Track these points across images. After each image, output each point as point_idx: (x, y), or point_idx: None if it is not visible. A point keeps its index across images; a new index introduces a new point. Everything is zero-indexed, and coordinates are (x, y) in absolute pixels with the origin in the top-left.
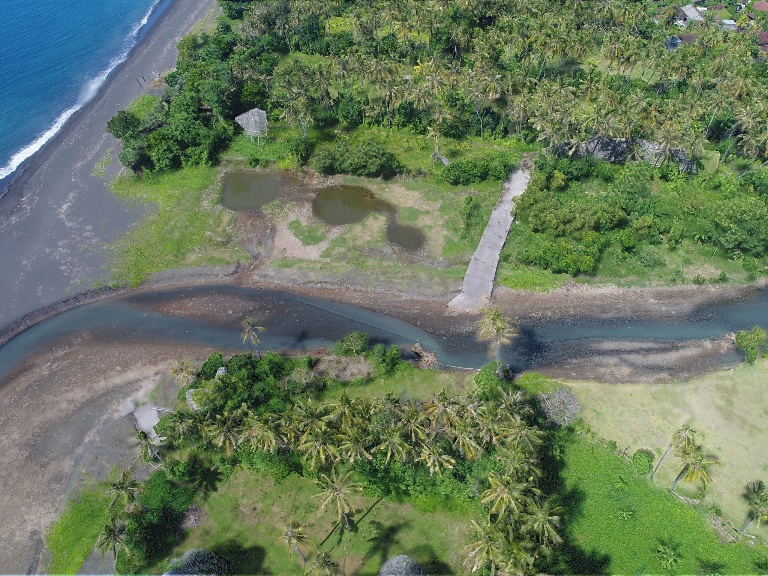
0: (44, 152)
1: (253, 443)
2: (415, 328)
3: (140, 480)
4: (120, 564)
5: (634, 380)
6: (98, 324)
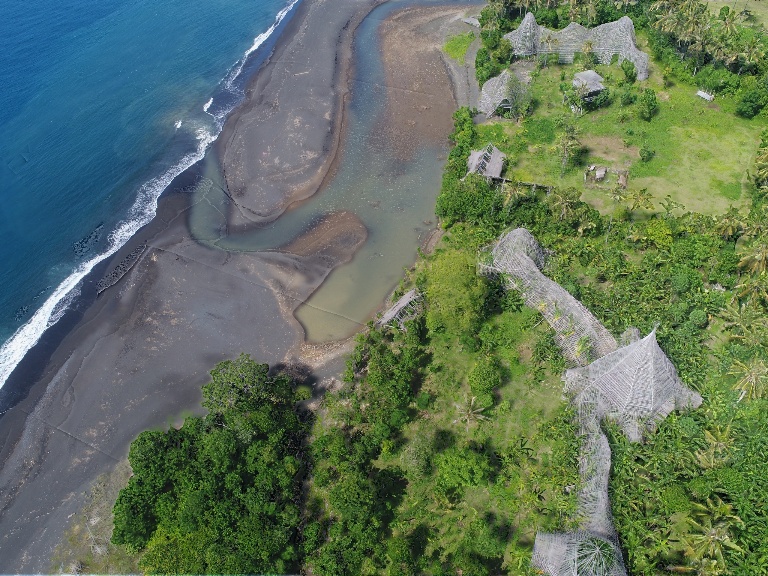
0: None
1: (538, 4)
2: None
3: (478, 32)
4: (489, 41)
5: None
6: (420, 0)
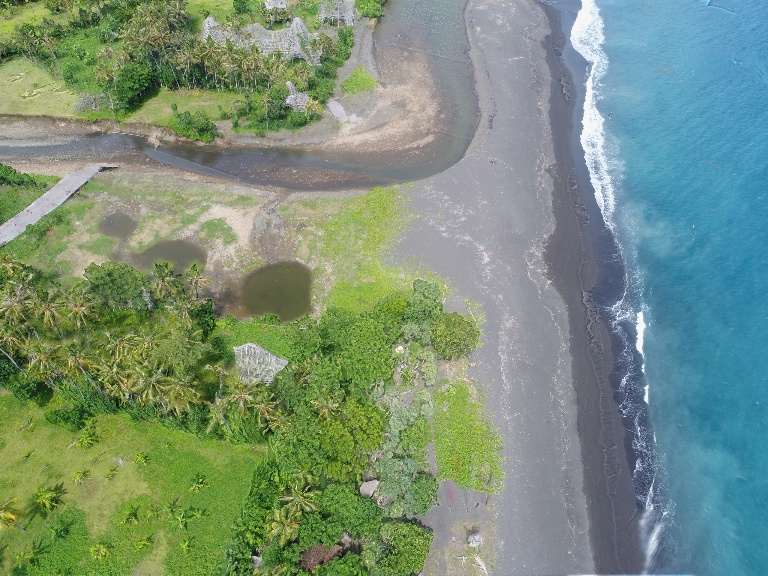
0: (590, 372)
1: None
2: (153, 157)
3: (335, 91)
4: None
5: (26, 124)
6: (398, 167)
